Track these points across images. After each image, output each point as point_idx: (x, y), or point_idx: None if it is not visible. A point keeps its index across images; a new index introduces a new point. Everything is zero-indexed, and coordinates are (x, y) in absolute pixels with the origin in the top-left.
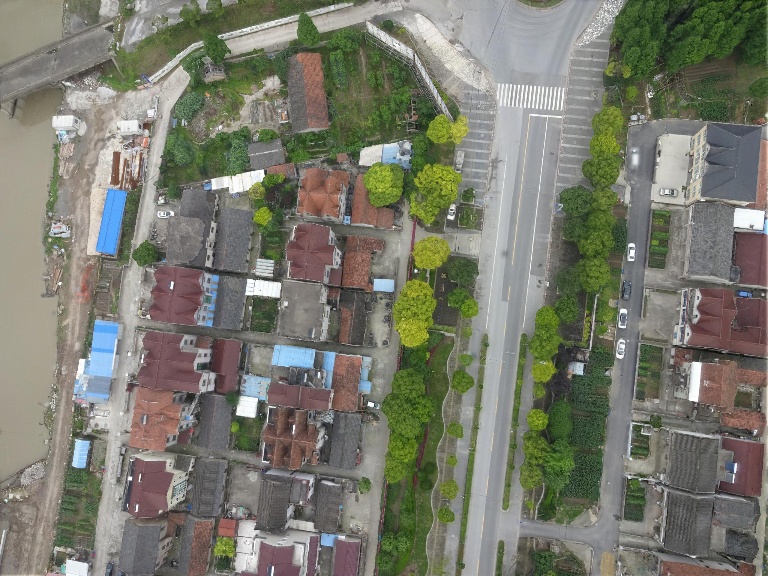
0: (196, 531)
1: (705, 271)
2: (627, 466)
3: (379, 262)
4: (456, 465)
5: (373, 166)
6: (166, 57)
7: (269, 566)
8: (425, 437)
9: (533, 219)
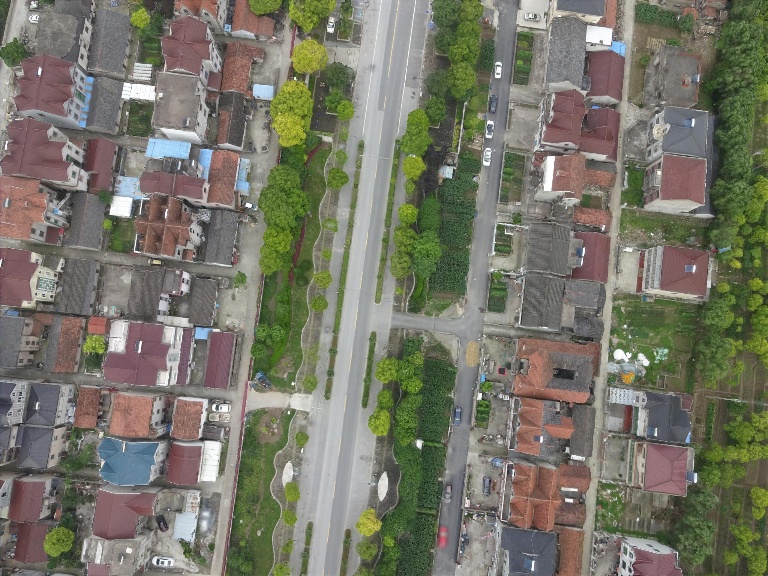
0: (64, 327)
1: (560, 78)
2: (492, 263)
3: (260, 72)
4: (332, 263)
5: None
6: None
7: (137, 343)
8: (302, 236)
9: (408, 35)
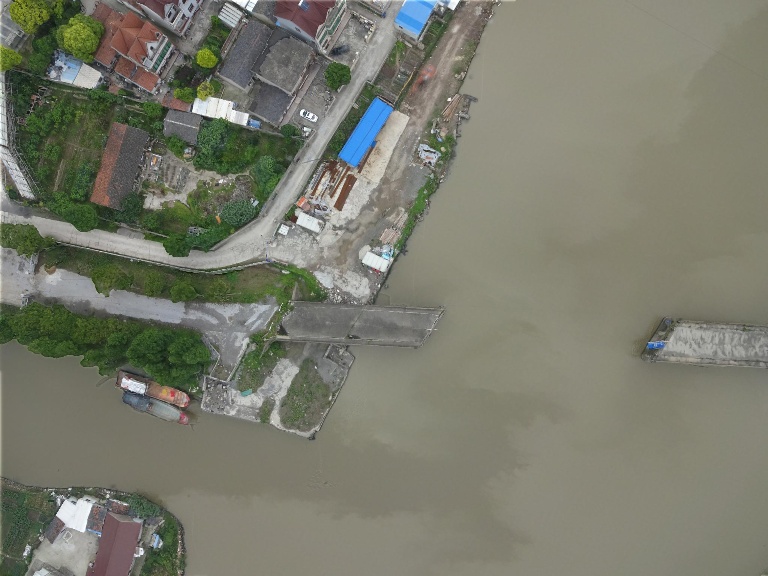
0: None
1: None
2: None
3: None
4: None
5: (79, 52)
6: (242, 277)
7: None
8: None
9: None
